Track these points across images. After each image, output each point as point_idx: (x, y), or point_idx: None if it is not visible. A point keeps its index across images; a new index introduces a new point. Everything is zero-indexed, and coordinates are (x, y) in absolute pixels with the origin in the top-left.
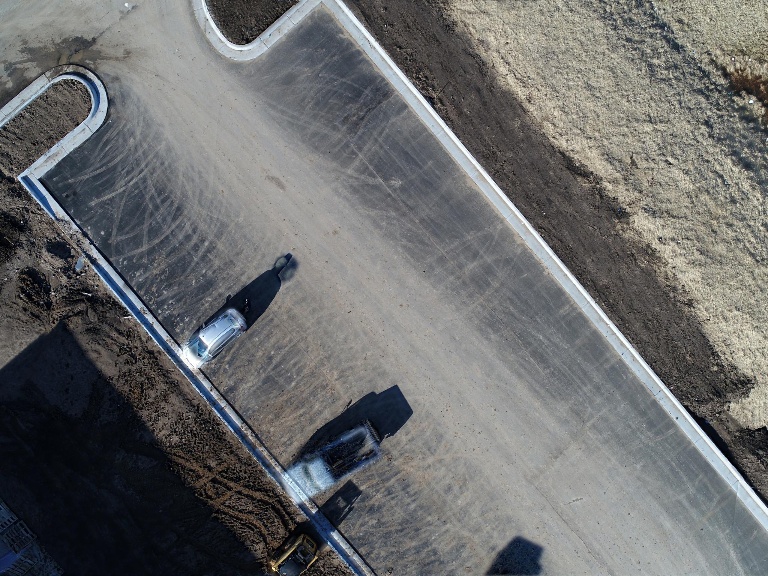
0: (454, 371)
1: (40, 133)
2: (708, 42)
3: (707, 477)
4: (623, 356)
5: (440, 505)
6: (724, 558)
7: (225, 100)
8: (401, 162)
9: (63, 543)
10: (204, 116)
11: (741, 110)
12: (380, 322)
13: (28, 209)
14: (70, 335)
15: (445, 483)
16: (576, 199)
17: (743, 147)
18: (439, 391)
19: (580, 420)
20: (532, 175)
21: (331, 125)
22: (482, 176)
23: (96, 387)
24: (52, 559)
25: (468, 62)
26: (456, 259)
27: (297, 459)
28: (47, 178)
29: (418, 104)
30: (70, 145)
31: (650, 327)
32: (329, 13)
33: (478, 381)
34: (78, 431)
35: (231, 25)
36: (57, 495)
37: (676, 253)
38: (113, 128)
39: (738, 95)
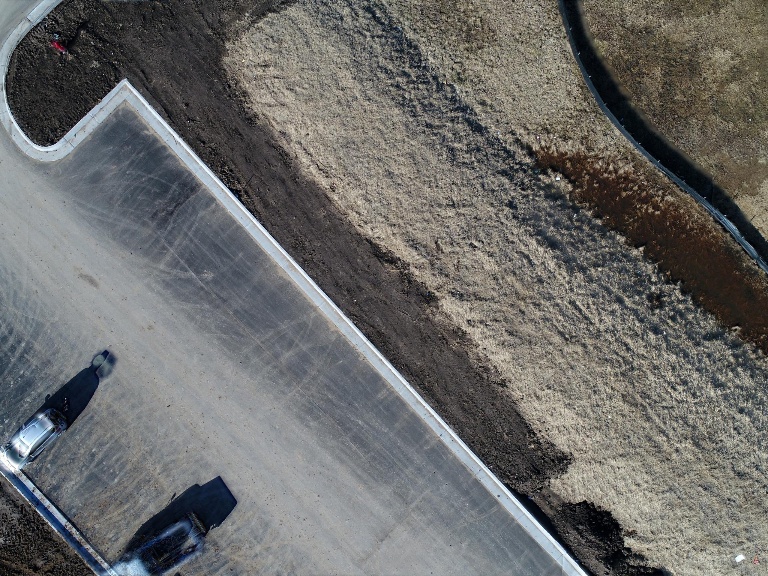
0: (276, 460)
1: None
2: (512, 122)
3: (532, 552)
4: (442, 437)
5: None
6: None
7: (35, 201)
8: (212, 255)
9: None
10: (14, 218)
11: (547, 188)
12: (199, 415)
13: None
14: None
15: (273, 571)
16: (385, 285)
17: (549, 225)
18: (262, 480)
19: (403, 502)
20: (341, 263)
21: (141, 221)
22: (293, 266)
23: None
24: None
25: (272, 154)
26: (272, 349)
27: (123, 555)
28: None
29: (226, 197)
30: None
31: (466, 408)
32: (133, 111)
33: (300, 468)
34: None
35: (35, 127)
36: None
37: (485, 335)
38: None
39: (544, 173)
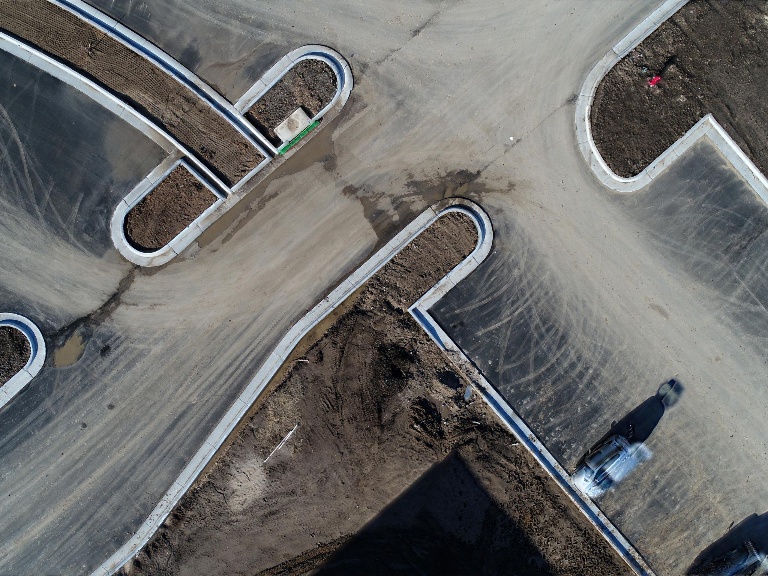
0: None
1: (428, 265)
2: None
3: None
4: None
5: None
6: None
7: (609, 230)
8: None
9: None
10: (588, 246)
11: None
12: (762, 445)
13: (416, 340)
14: (462, 463)
15: None
16: None
17: None
18: None
19: None
20: None
21: (714, 254)
22: None
23: (488, 514)
24: None
25: None
26: None
27: None
28: (435, 309)
29: None
30: (457, 276)
31: None
32: (712, 145)
33: None
34: (472, 557)
35: (618, 158)
36: None
37: None
38: (498, 259)
39: None
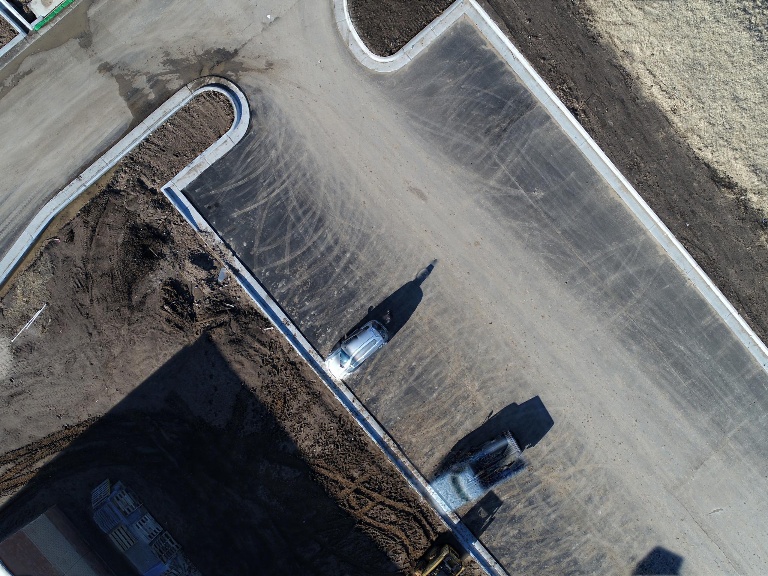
0: (595, 382)
1: (183, 145)
2: None
3: None
4: (765, 367)
5: (580, 515)
6: None
7: (367, 111)
8: (543, 173)
9: (207, 553)
10: (346, 127)
11: None
12: (522, 333)
13: (170, 220)
14: (213, 346)
15: (585, 494)
16: (720, 210)
17: None
18: (580, 402)
19: (721, 431)
20: (676, 186)
21: (473, 136)
22: (625, 187)
23: (239, 398)
24: (196, 569)
25: (612, 73)
26: (598, 270)
27: (439, 470)
28: (189, 190)
29: (561, 115)
30: (212, 157)
31: None
32: (472, 24)
33: (619, 392)
34: (222, 442)
35: (374, 37)
36: (201, 506)
37: None
38: (255, 140)
39: None
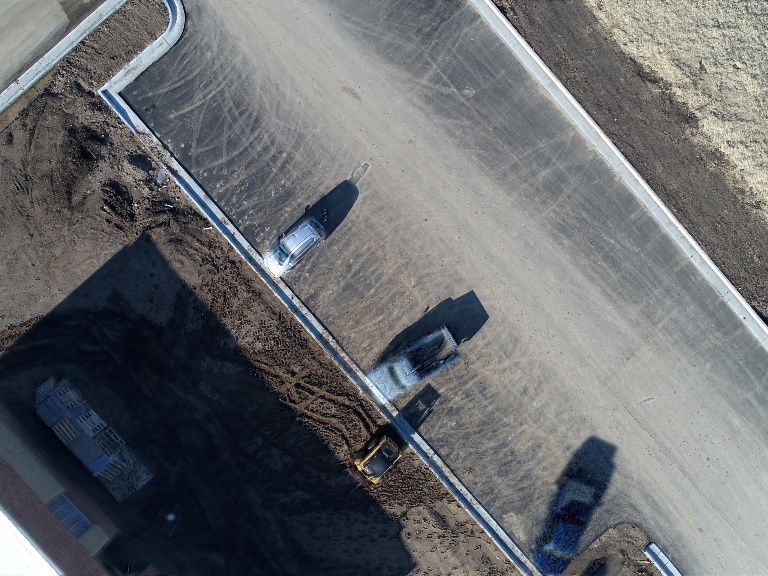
0: (528, 276)
1: (119, 47)
2: None
3: None
4: (692, 258)
5: (516, 407)
6: None
7: (301, 13)
8: (475, 72)
9: (151, 449)
10: (280, 29)
11: None
12: (456, 229)
13: (108, 123)
14: (153, 246)
15: (520, 385)
16: (647, 105)
17: None
18: (514, 296)
19: (651, 322)
20: (603, 82)
21: (406, 36)
22: (554, 84)
23: (180, 296)
24: (141, 464)
25: None
26: (529, 166)
27: (377, 364)
28: (127, 92)
29: (491, 14)
30: (149, 59)
31: (719, 229)
32: None
33: (552, 285)
34: (163, 339)
35: None
36: (144, 402)
37: (744, 156)
38: (191, 42)
39: None
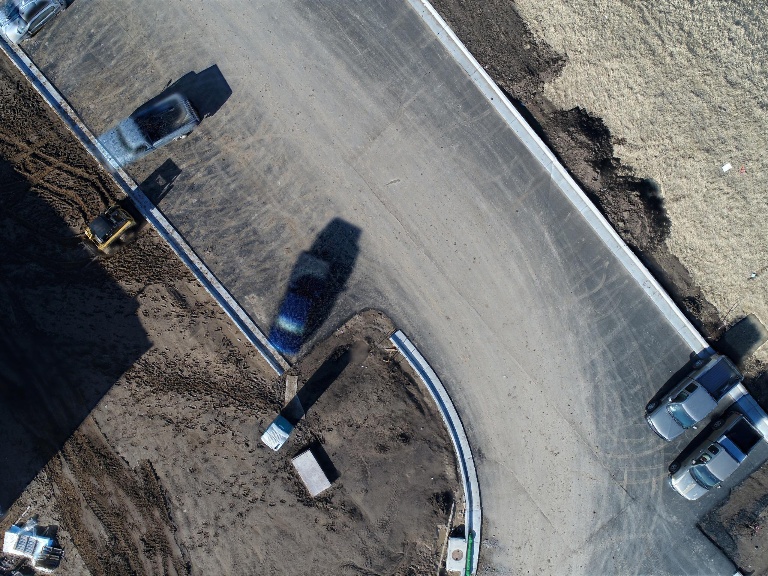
0: (273, 51)
1: None
2: None
3: (522, 159)
4: (439, 36)
5: (260, 186)
6: (539, 240)
7: None
8: None
9: None
10: None
11: None
12: (199, 1)
13: None
14: None
15: (264, 164)
16: None
17: None
18: (258, 71)
19: (397, 101)
20: None
21: None
22: None
23: None
24: None
25: None
26: None
27: (116, 137)
28: None
29: None
30: None
31: (464, 5)
32: None
33: (296, 61)
34: None
35: None
36: None
37: None
38: None
39: None
